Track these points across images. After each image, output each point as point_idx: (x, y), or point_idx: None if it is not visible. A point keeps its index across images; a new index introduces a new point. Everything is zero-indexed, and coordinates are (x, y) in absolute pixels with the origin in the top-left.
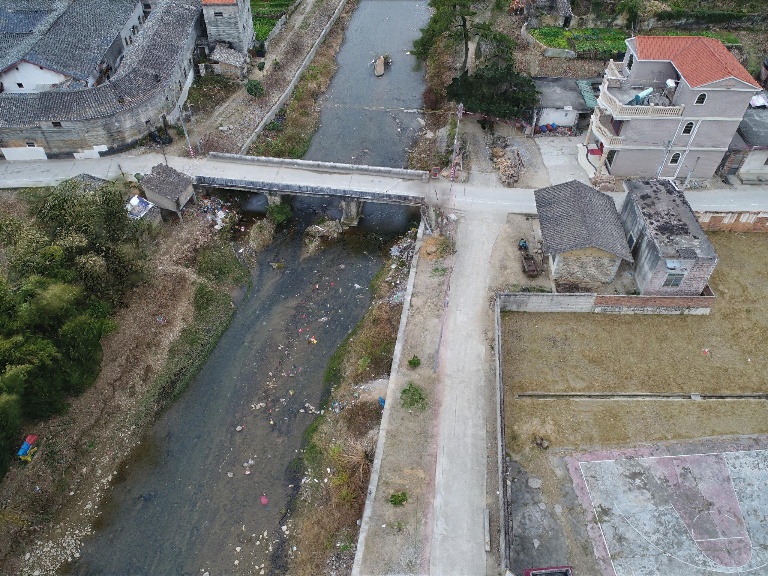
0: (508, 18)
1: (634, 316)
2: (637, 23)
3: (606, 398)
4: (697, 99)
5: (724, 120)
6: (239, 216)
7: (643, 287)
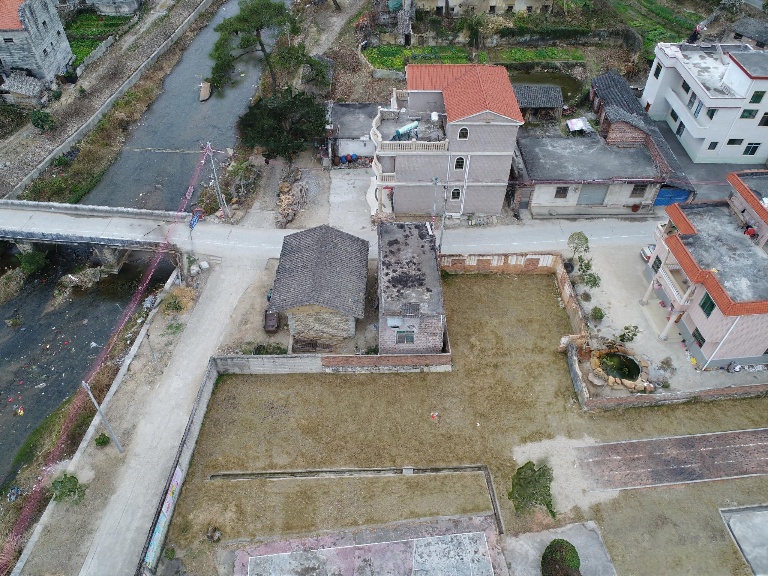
0: (353, 36)
1: (370, 376)
2: (479, 40)
3: (310, 475)
4: (459, 134)
5: (494, 154)
6: None
7: None
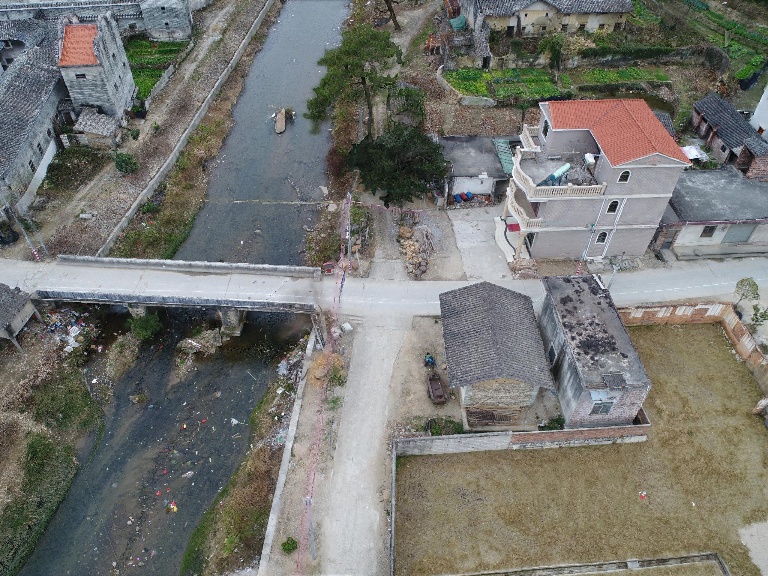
0: (424, 58)
1: (559, 450)
2: (561, 62)
3: (526, 574)
4: (620, 177)
5: (652, 197)
6: (97, 331)
7: (567, 415)
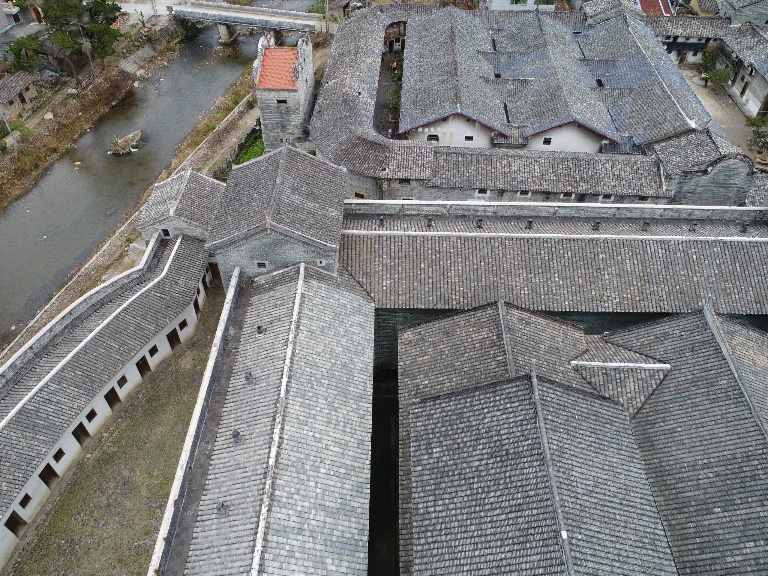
0: None
1: None
2: None
3: None
4: None
5: None
6: None
7: None
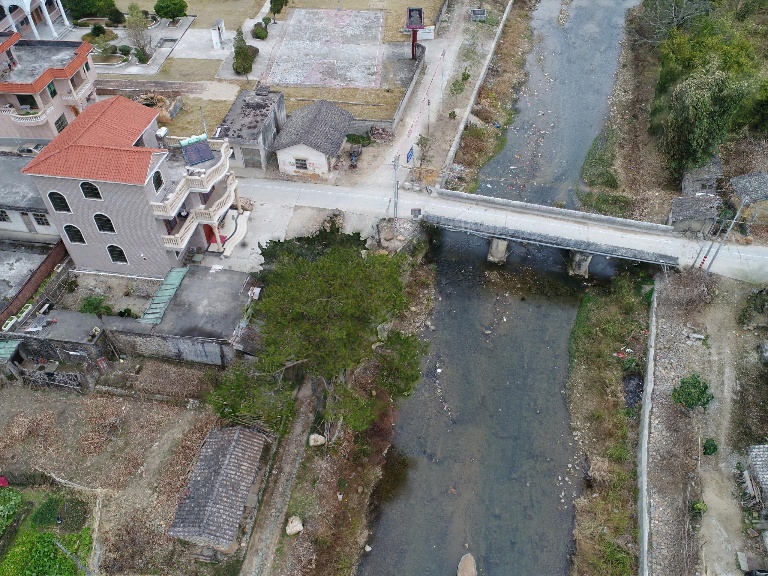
0: None
1: None
2: None
3: None
4: None
5: None
6: None
7: None
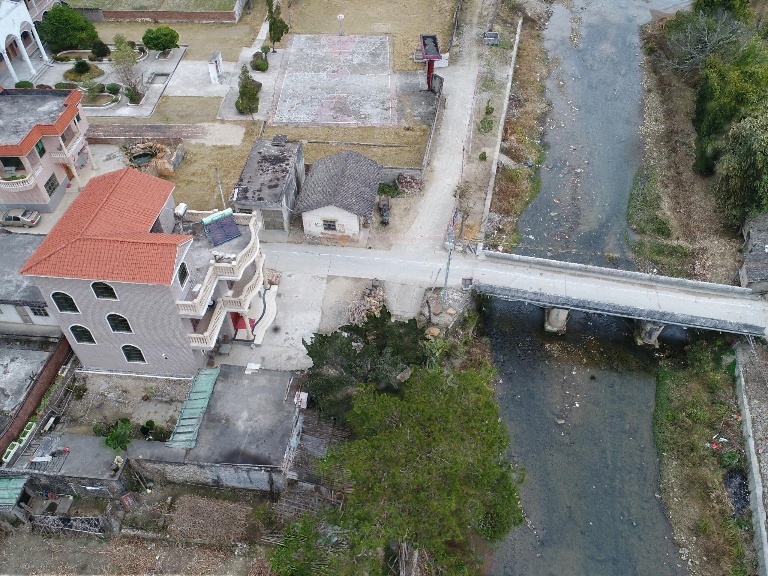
0: None
1: None
2: None
3: None
4: None
5: None
6: None
7: None
